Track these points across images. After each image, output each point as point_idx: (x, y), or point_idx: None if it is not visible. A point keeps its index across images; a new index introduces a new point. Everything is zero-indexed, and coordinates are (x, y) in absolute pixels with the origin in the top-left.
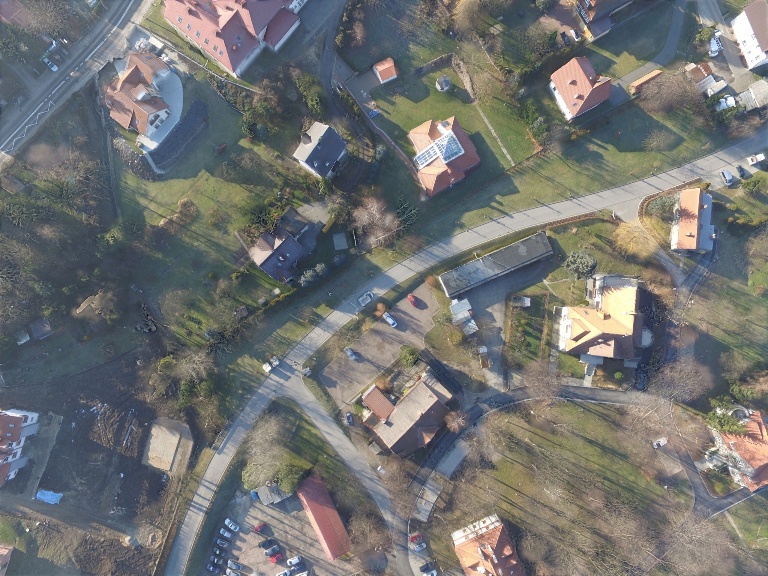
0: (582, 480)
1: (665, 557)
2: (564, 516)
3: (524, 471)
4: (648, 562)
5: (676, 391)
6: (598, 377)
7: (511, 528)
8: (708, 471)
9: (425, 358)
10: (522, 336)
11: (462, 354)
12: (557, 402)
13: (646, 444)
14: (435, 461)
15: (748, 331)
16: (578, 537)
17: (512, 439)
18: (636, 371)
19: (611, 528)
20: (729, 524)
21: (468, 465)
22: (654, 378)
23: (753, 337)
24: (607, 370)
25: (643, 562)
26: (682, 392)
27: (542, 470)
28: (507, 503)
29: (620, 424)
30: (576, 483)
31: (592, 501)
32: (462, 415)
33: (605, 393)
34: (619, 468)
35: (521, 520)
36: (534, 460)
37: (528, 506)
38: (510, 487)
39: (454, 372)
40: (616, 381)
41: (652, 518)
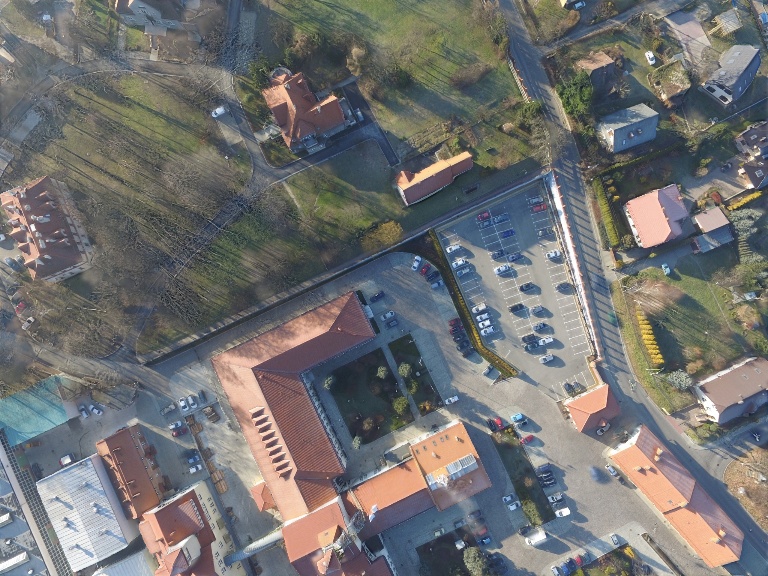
0: (148, 151)
1: (225, 226)
2: (130, 186)
3: (92, 141)
4: (209, 231)
5: (238, 65)
6: (164, 50)
7: (75, 194)
8: (266, 141)
9: (1, 32)
10: (92, 10)
11: (35, 28)
12: (124, 74)
13: (208, 115)
14: (7, 130)
15: (307, 6)
16: (143, 206)
17: (81, 110)
18: (200, 45)
19: (174, 197)
20: (287, 194)
21: (38, 134)
22: (216, 51)
23: (312, 12)
24: (172, 43)
25: (205, 231)
26: (244, 66)
27: (110, 141)
28: (75, 172)
29: (183, 95)
30: (142, 154)
31: (157, 171)
32: (11, 69)
33: (170, 66)
34: (182, 139)
35: (88, 188)
36: (101, 130)
37: (96, 175)
38: (79, 157)
39: (28, 46)
40: (179, 53)
41: (214, 188)
